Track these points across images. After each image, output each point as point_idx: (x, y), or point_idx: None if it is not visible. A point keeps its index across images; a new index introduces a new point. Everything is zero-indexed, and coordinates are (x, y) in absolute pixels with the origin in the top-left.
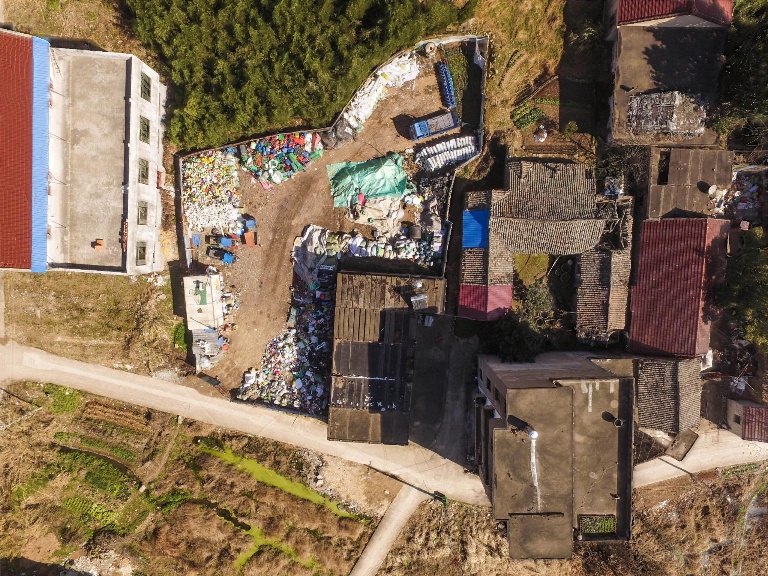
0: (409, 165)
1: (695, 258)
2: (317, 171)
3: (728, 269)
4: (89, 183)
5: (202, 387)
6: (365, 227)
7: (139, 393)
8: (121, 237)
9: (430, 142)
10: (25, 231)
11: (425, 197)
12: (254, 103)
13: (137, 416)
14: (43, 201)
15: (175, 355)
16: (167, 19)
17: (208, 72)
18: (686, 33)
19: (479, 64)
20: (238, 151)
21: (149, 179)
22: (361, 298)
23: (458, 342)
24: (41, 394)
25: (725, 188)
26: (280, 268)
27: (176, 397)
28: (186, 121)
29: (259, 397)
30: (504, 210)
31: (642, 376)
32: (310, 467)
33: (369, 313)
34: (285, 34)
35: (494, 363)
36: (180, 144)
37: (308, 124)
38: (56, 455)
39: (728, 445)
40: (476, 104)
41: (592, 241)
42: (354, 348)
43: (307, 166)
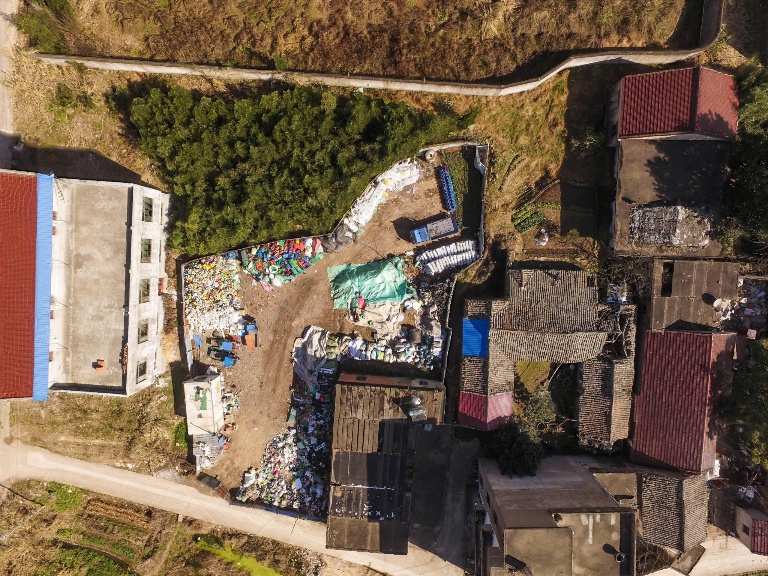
0: (409, 268)
1: (700, 374)
2: (317, 273)
3: (734, 384)
4: (91, 305)
5: (202, 486)
6: (365, 329)
7: (140, 492)
8: (122, 358)
9: (430, 244)
10: (28, 356)
11: (425, 302)
12: (254, 218)
13: (138, 513)
14: (46, 326)
15: (176, 454)
16: (169, 138)
17: (209, 184)
18: (689, 146)
19: (479, 169)
20: (239, 255)
21: (150, 295)
22: (360, 409)
23: (458, 445)
24: (44, 492)
25: None
26: (280, 368)
27: (176, 496)
28: (187, 233)
29: (259, 497)
30: (504, 321)
31: (646, 490)
32: (309, 566)
33: (368, 424)
34: (285, 149)
35: (494, 476)
36: (182, 248)
37: (308, 231)
38: (58, 551)
39: (737, 552)
40: (477, 207)
41: (594, 351)
42: (353, 457)
43: (307, 269)
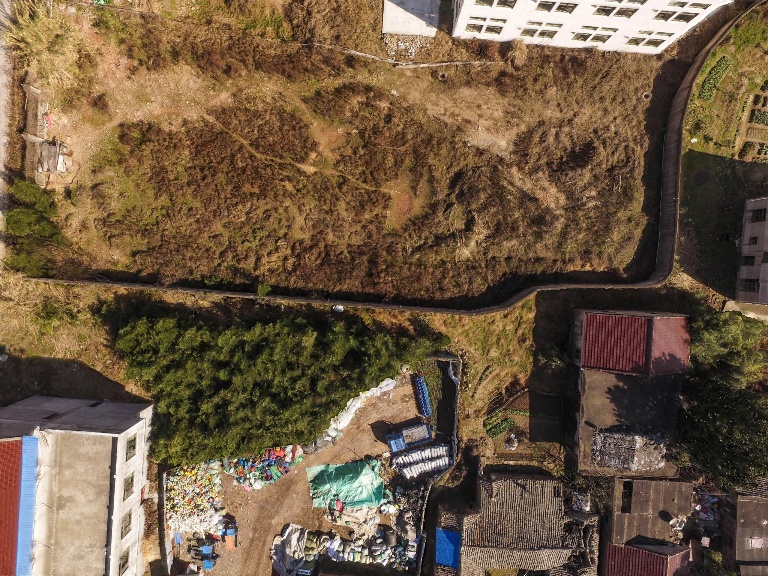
0: (386, 471)
1: None
2: (297, 473)
3: None
4: (73, 545)
5: None
6: (343, 528)
7: None
8: None
9: None
10: None
11: (400, 507)
12: (236, 443)
13: None
14: (27, 570)
15: None
16: None
17: (193, 402)
18: None
19: (453, 380)
20: (221, 459)
21: (132, 523)
22: None
23: None
24: None
25: (685, 515)
26: (259, 565)
27: None
28: (170, 452)
29: None
30: (475, 537)
31: None
32: None
33: None
34: None
35: None
36: None
37: None
38: None
39: None
40: (450, 412)
41: (560, 561)
42: None
43: None
